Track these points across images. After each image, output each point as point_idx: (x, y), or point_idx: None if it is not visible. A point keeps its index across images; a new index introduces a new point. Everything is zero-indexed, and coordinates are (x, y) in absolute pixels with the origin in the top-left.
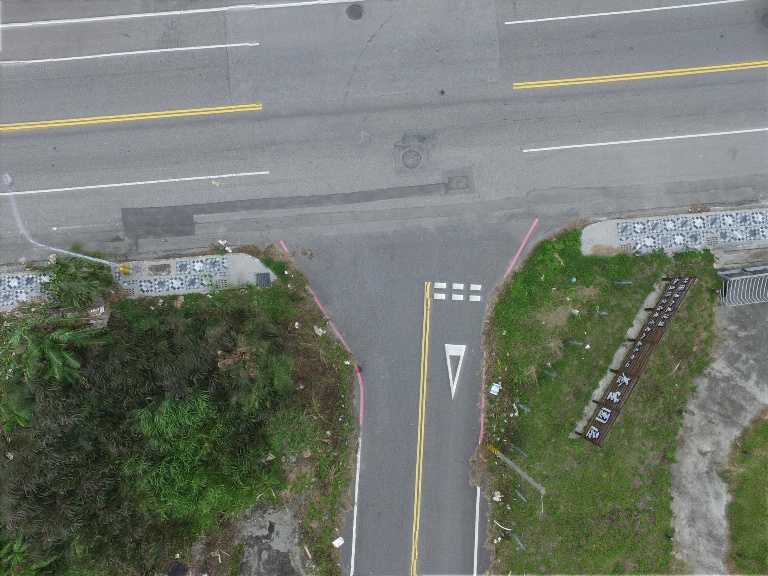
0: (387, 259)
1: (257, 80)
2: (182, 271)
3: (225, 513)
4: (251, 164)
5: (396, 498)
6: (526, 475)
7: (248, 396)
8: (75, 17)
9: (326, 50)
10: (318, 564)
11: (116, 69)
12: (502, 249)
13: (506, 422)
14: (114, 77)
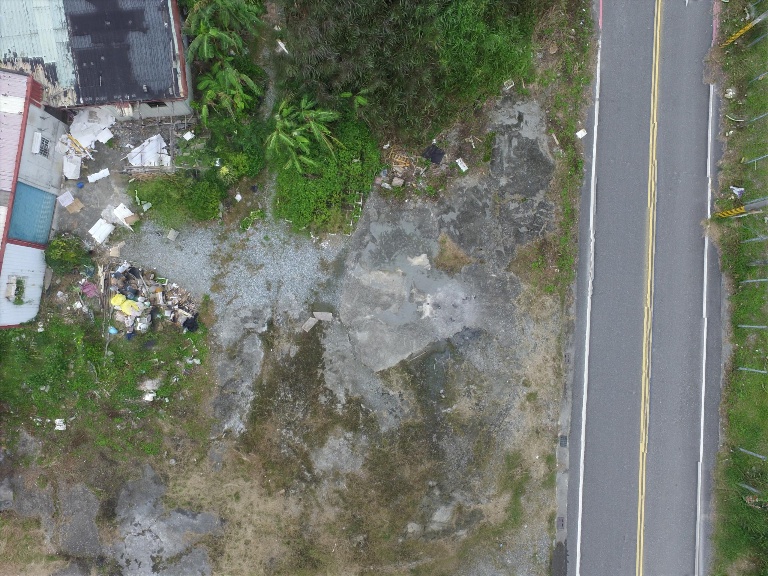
0: None
1: None
2: None
3: (479, 101)
4: None
5: (635, 94)
6: None
7: None
8: None
9: None
10: (565, 149)
11: None
12: None
13: (737, 26)
14: None
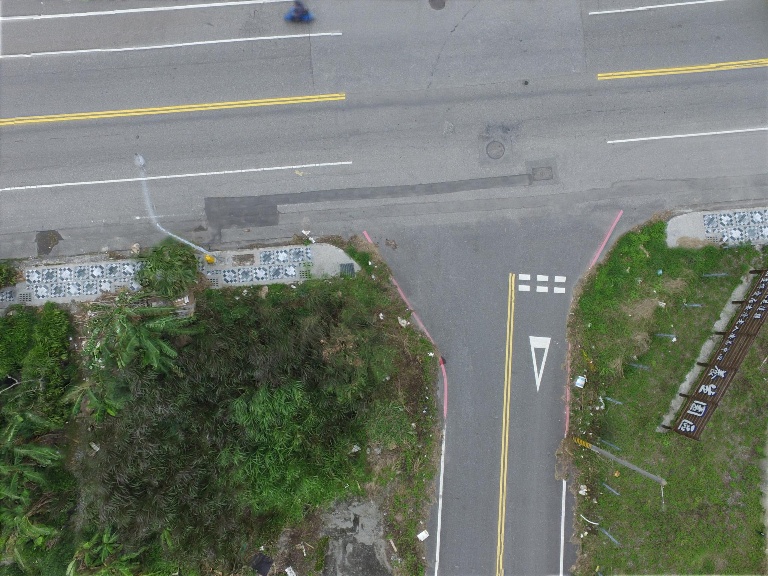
0: (471, 250)
1: (340, 70)
2: (266, 261)
3: (310, 505)
4: (334, 154)
5: (481, 491)
6: (636, 467)
7: (343, 386)
8: (158, 6)
9: (409, 40)
10: (404, 557)
11: (199, 58)
12: (587, 241)
13: (592, 415)
14: (197, 66)
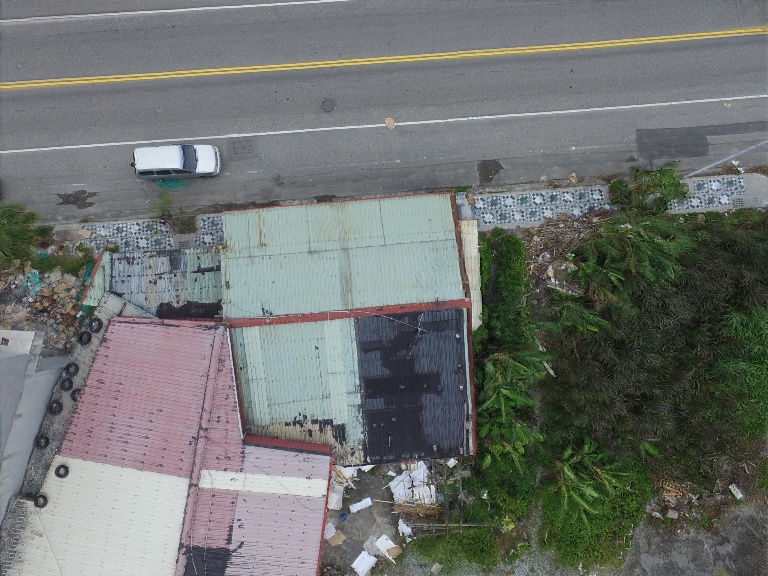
0: None
1: (763, 5)
2: (700, 190)
3: None
4: (761, 87)
5: None
6: None
7: None
8: None
9: None
10: None
11: None
12: None
13: None
14: (627, 2)
